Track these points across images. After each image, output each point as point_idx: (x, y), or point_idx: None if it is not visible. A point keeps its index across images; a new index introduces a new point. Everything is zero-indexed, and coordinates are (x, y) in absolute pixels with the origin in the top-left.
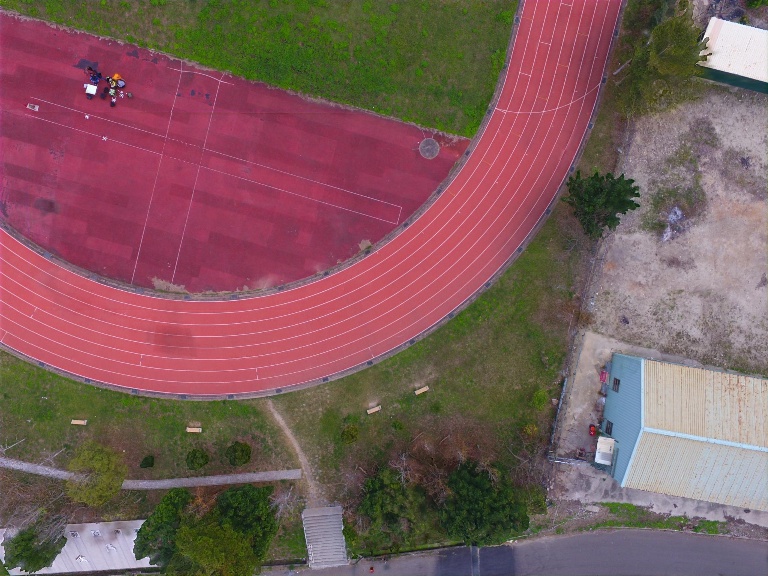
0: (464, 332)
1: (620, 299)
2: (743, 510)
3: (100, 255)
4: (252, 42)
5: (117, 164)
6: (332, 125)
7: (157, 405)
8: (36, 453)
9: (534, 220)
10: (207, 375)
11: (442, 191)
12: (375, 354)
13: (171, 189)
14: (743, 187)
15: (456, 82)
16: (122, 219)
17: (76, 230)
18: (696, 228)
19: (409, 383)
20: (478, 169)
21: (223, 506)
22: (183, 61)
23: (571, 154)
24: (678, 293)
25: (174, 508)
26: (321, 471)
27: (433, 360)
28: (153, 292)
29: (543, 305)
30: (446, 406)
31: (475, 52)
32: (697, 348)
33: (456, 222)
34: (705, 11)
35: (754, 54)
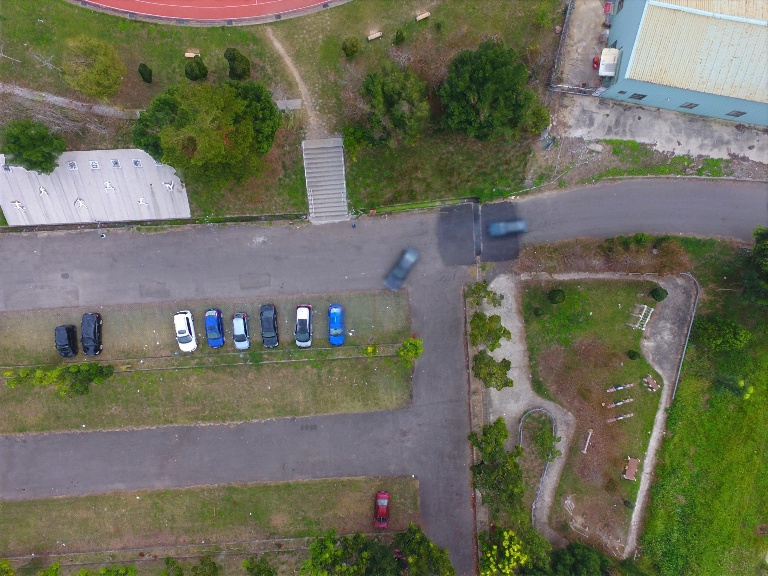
0: None
1: None
2: (747, 147)
3: None
4: None
5: None
6: None
7: (155, 31)
8: (32, 78)
9: None
10: None
11: None
12: None
13: None
14: None
15: None
16: None
17: None
18: None
19: (410, 10)
20: None
21: None
22: None
23: None
24: None
25: None
26: (321, 101)
27: None
28: None
29: None
30: (448, 34)
31: None
32: None
33: None
34: None
35: None
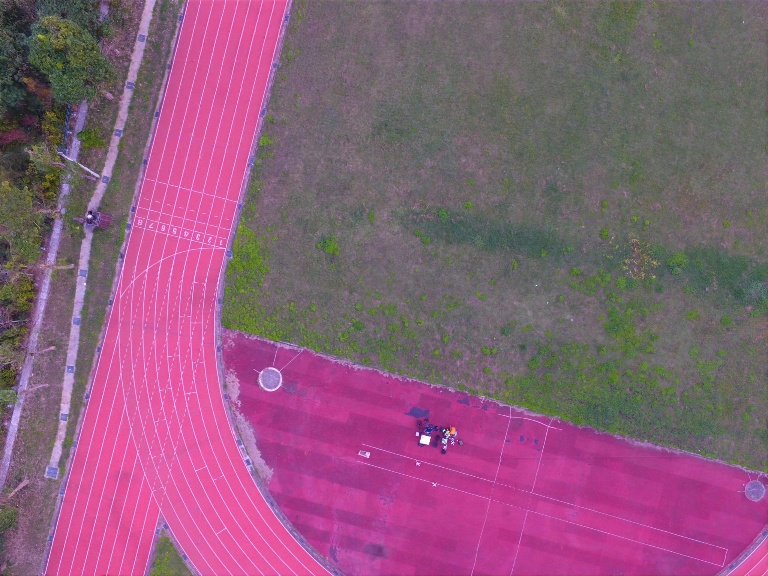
0: None
1: None
2: None
3: None
4: (581, 389)
5: (446, 509)
6: (658, 468)
7: None
8: None
9: None
10: None
11: (767, 533)
12: None
13: (499, 533)
14: None
15: None
16: (450, 564)
17: (404, 575)
18: None
19: None
20: None
21: None
22: (512, 407)
23: None
24: None
25: None
26: None
27: None
28: None
29: None
30: None
31: None
32: None
33: None
34: None
35: None
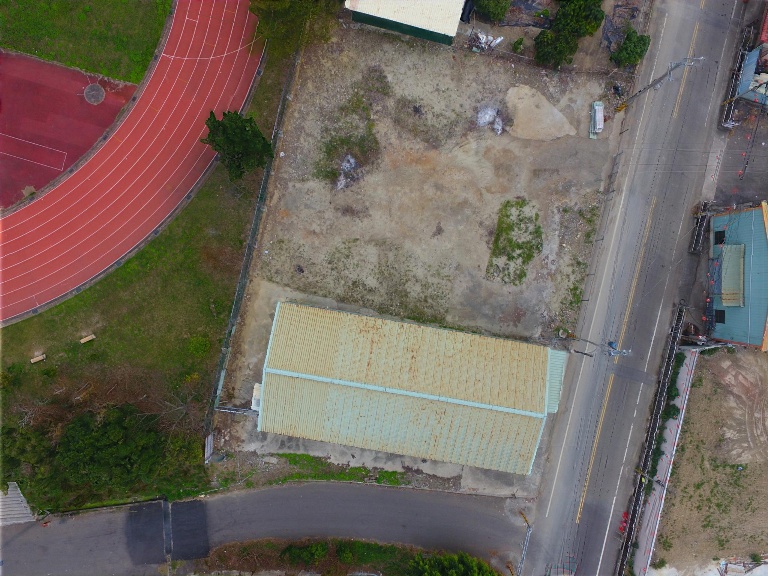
0: (131, 280)
1: (294, 248)
2: (421, 460)
3: None
4: None
5: None
6: None
7: None
8: None
9: (203, 167)
10: None
11: (109, 137)
12: (40, 302)
13: None
14: (416, 135)
15: (121, 27)
16: None
17: None
18: (370, 176)
19: (76, 332)
20: (145, 115)
21: None
22: None
23: (240, 101)
24: (353, 242)
25: None
26: None
27: (100, 308)
28: None
29: (213, 253)
30: (114, 355)
31: None
32: (373, 297)
33: (123, 168)
34: None
35: None
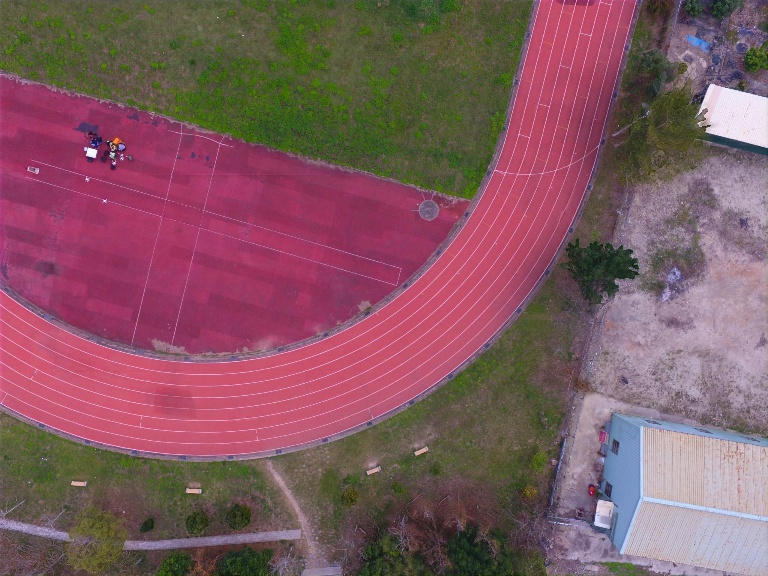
0: (463, 393)
1: (619, 359)
2: None
3: (100, 317)
4: (252, 105)
5: (117, 226)
6: (332, 187)
7: (157, 466)
8: (36, 514)
9: (533, 281)
10: (207, 436)
11: (441, 252)
12: (375, 415)
13: (171, 251)
14: (742, 248)
15: (455, 144)
16: (122, 281)
17: (76, 292)
18: (695, 288)
19: (409, 444)
20: (477, 230)
21: (223, 573)
22: (183, 124)
23: (570, 215)
24: (677, 353)
25: (174, 575)
26: (321, 531)
27: (432, 421)
28: (153, 353)
29: (542, 366)
30: (445, 467)
31: (474, 114)
32: (696, 408)
33: (455, 283)
34: (704, 73)
35: (752, 120)
